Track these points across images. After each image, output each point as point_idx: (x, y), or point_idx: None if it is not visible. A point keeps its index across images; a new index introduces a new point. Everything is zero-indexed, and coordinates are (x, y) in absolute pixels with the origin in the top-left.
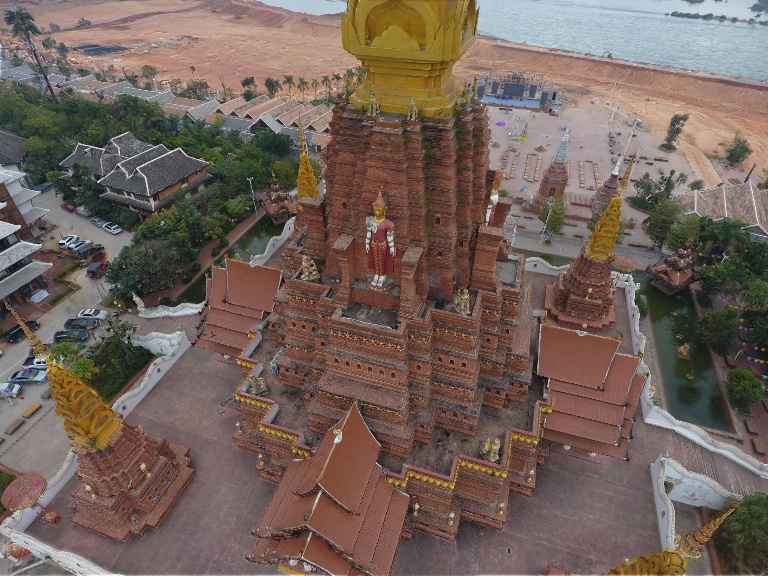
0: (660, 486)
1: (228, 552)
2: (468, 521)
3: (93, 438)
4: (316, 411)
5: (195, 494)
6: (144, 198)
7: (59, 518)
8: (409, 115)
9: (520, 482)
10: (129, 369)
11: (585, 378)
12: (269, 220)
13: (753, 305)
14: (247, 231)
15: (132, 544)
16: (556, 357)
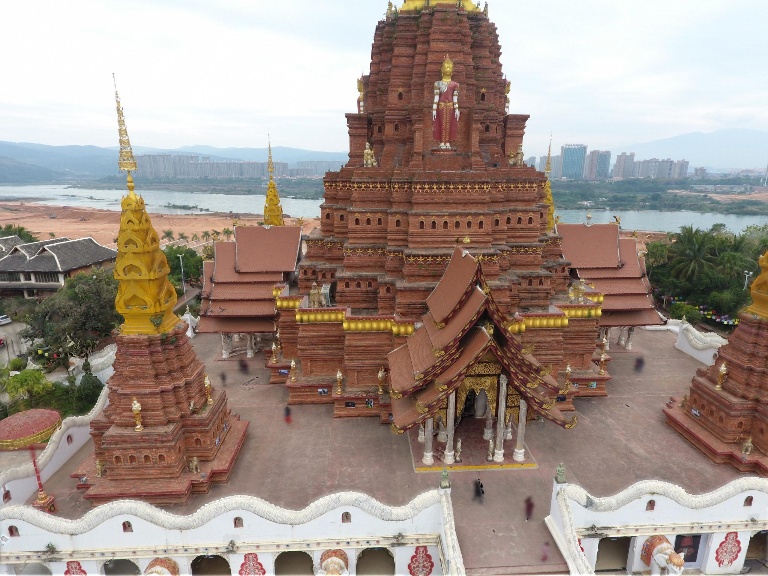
0: (696, 345)
1: (341, 475)
2: (574, 398)
3: (160, 314)
4: (407, 286)
5: (259, 446)
6: (50, 278)
7: (54, 508)
8: (458, 4)
9: (597, 357)
10: (82, 401)
11: (605, 261)
12: (199, 302)
13: (658, 259)
14: (179, 307)
15: (195, 503)
16: (576, 250)
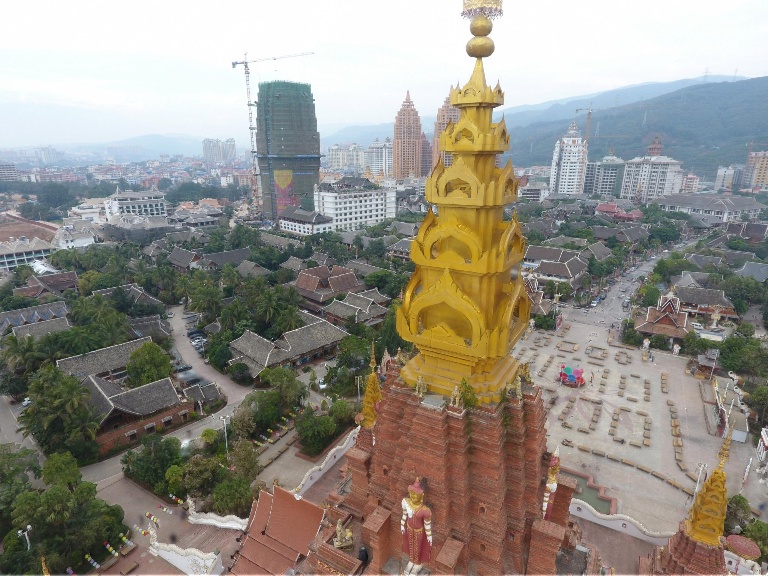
0: None
1: None
2: None
3: None
4: None
5: None
6: None
7: None
8: None
9: None
10: None
11: None
12: None
13: None
14: None
15: None
16: None
